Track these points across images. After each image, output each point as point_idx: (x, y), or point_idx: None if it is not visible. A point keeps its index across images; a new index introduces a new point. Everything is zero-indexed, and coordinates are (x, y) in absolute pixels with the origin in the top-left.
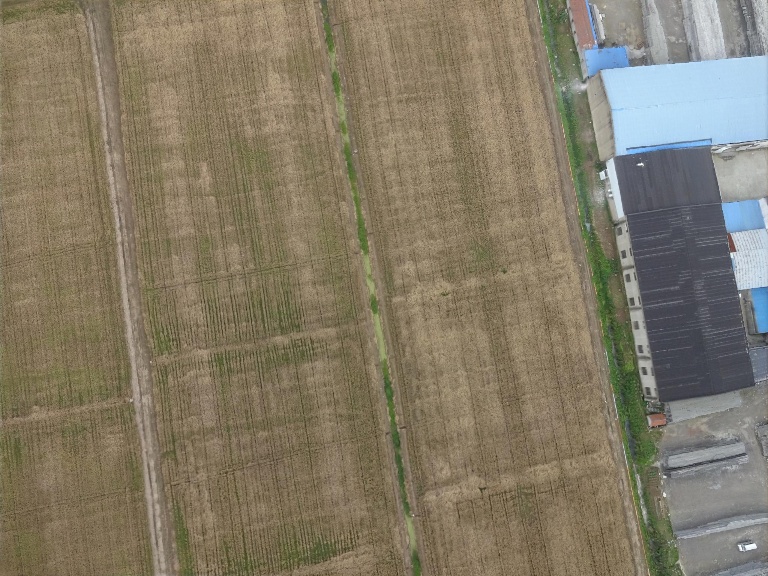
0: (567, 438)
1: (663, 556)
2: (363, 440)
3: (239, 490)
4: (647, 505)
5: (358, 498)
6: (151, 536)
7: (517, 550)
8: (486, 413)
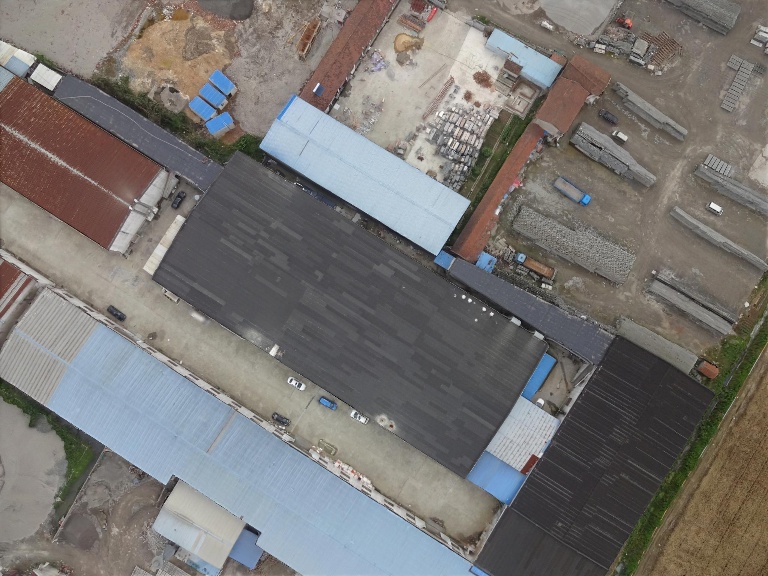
0: None
1: None
2: None
3: None
4: None
5: None
6: None
7: None
8: None
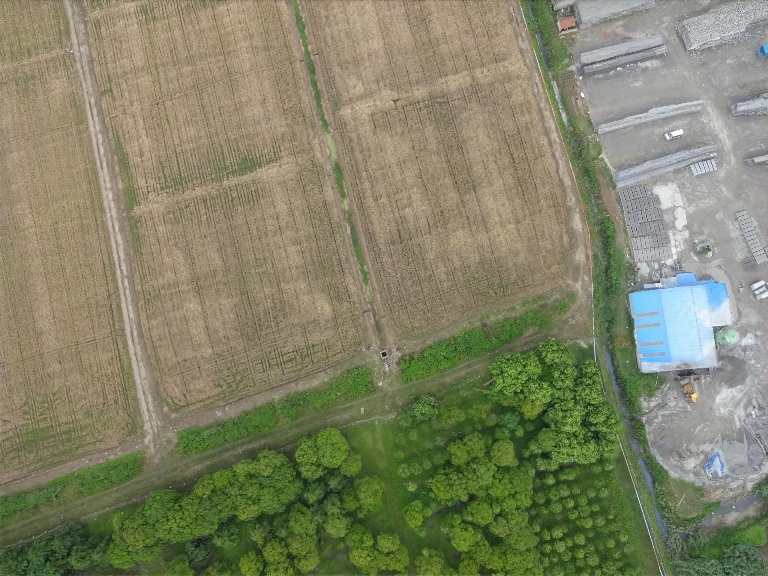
0: (476, 50)
1: (584, 149)
2: (279, 67)
3: (170, 117)
4: (565, 107)
5: (278, 117)
6: (96, 161)
7: (434, 152)
8: (394, 34)
